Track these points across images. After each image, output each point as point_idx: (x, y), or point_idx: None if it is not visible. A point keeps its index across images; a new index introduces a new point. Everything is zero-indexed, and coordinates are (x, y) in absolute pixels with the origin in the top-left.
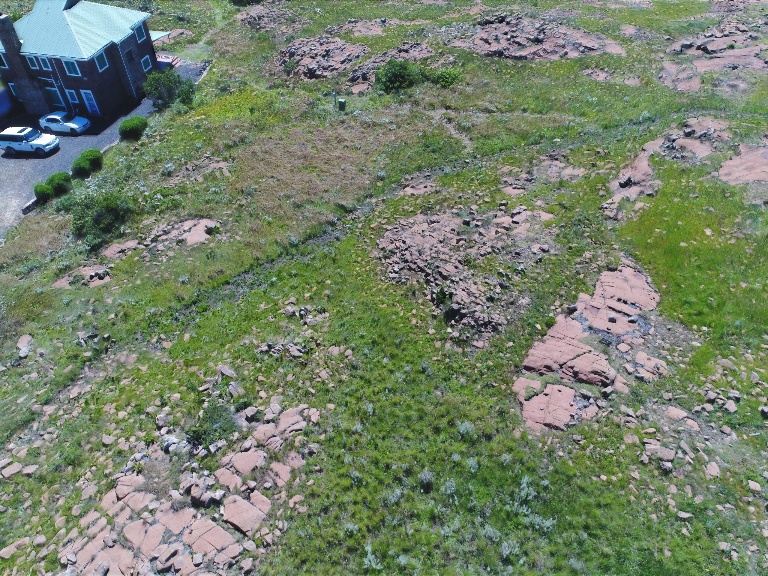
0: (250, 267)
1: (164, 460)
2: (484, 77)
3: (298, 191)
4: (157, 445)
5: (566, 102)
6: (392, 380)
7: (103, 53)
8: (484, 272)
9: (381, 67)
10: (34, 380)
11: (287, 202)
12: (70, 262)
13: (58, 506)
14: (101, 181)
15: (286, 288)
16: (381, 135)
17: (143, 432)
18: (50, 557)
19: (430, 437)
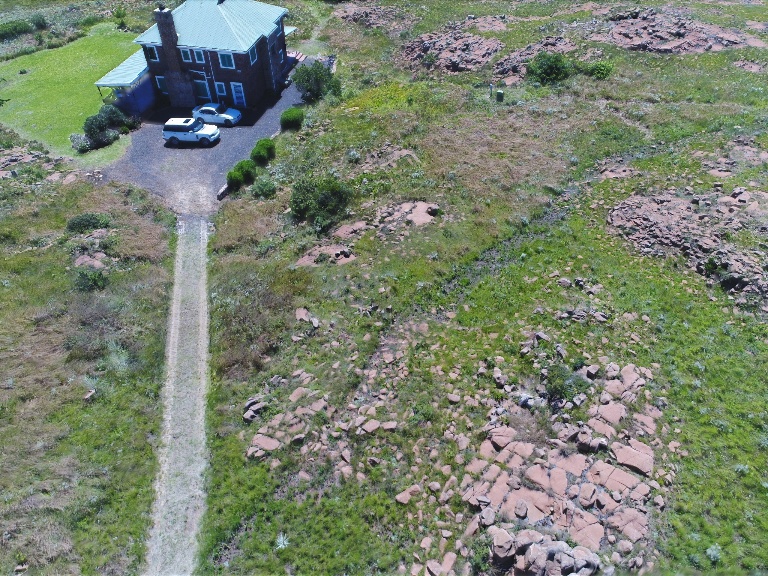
0: (492, 245)
1: (525, 414)
2: (635, 69)
3: (500, 176)
4: (511, 401)
5: (732, 92)
6: (702, 342)
7: (254, 46)
8: (745, 245)
9: (530, 60)
10: (337, 348)
11: (494, 186)
12: (305, 242)
13: (434, 457)
14: (286, 168)
15: (540, 263)
16: (554, 124)
17: (485, 391)
18: (452, 501)
19: (766, 390)
